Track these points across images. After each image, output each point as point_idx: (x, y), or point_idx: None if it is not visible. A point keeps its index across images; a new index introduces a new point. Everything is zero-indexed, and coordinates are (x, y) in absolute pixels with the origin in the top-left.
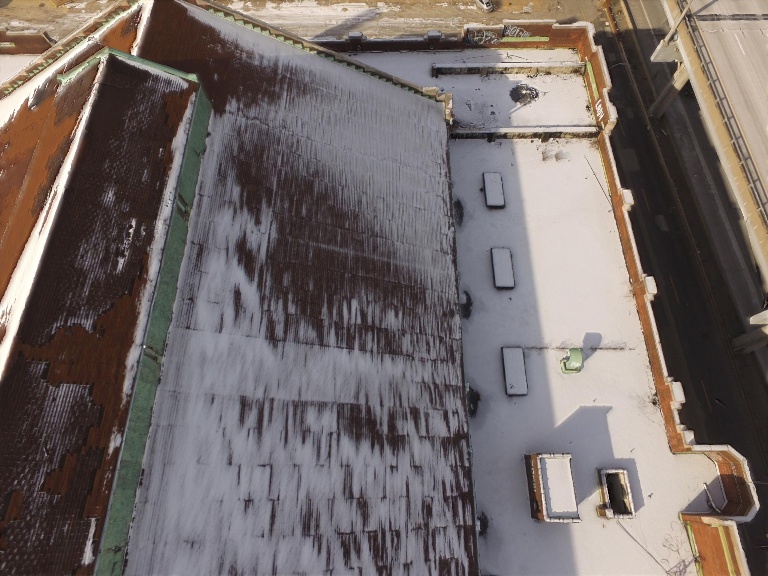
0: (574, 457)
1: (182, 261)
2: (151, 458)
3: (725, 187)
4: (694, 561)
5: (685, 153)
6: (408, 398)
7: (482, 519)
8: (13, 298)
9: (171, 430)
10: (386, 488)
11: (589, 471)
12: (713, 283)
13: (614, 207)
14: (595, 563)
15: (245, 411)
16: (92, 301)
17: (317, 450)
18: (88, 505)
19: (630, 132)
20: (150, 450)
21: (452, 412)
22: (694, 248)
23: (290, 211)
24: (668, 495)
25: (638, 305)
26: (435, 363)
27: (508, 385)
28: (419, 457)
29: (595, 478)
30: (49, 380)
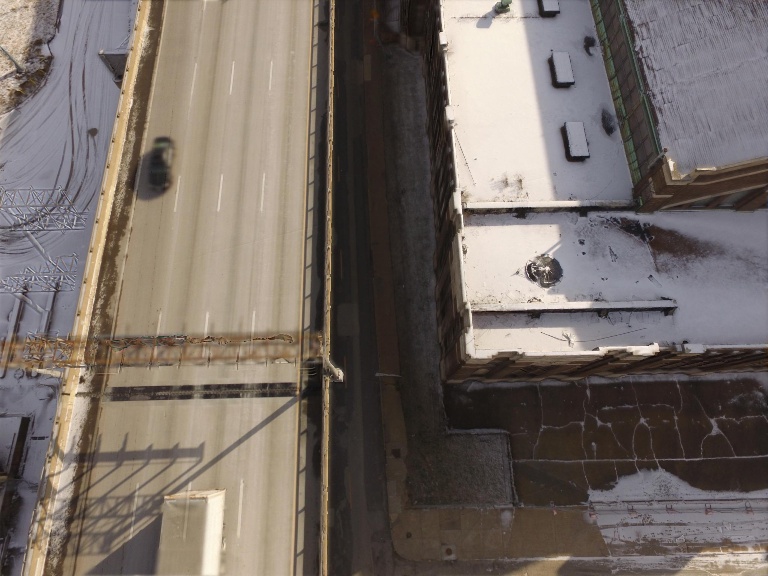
0: None
1: None
2: None
3: None
4: None
5: None
6: None
7: None
8: None
9: None
10: None
11: None
12: None
13: None
14: None
15: None
16: None
17: None
18: None
19: (336, 364)
20: None
21: None
22: None
23: None
24: None
25: None
26: None
27: None
28: None
29: None
30: None
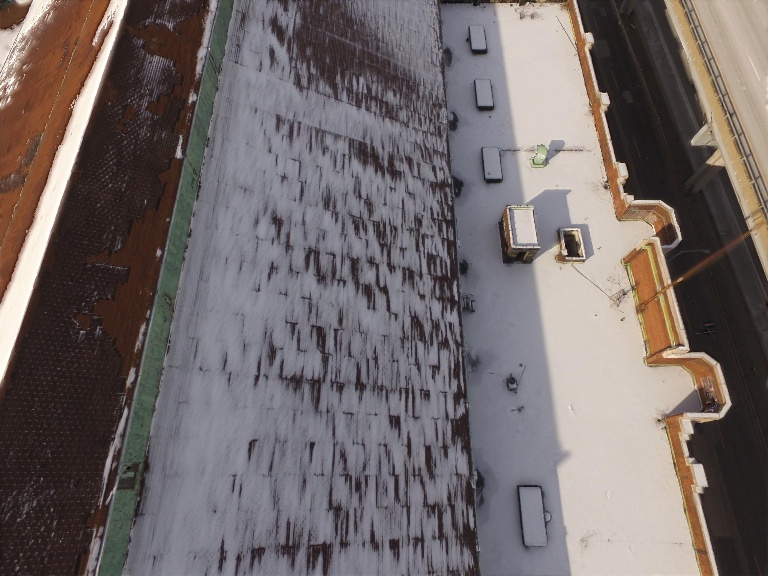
0: (539, 223)
1: (230, 20)
2: (214, 133)
3: (685, 69)
4: (631, 290)
5: (651, 43)
6: (404, 150)
7: (463, 264)
8: (115, 6)
9: (227, 121)
10: (386, 199)
11: (550, 233)
12: (670, 141)
13: (579, 52)
14: (553, 292)
15: (280, 124)
16: (172, 13)
17: (334, 162)
18: (177, 127)
19: (603, 27)
20: (213, 128)
21: (439, 168)
22: (655, 115)
23: (310, 8)
24: (613, 248)
25: (595, 120)
26: (426, 134)
27: (486, 173)
28: (412, 188)
29: (555, 237)
30: (146, 51)
